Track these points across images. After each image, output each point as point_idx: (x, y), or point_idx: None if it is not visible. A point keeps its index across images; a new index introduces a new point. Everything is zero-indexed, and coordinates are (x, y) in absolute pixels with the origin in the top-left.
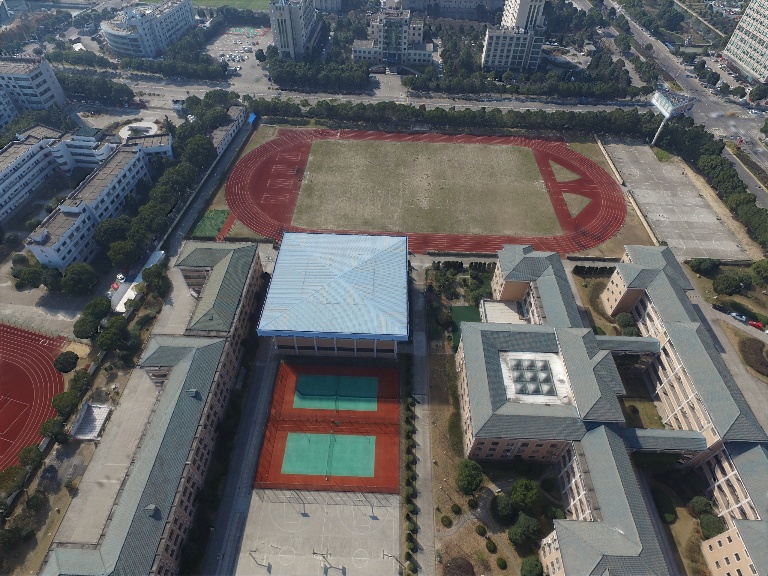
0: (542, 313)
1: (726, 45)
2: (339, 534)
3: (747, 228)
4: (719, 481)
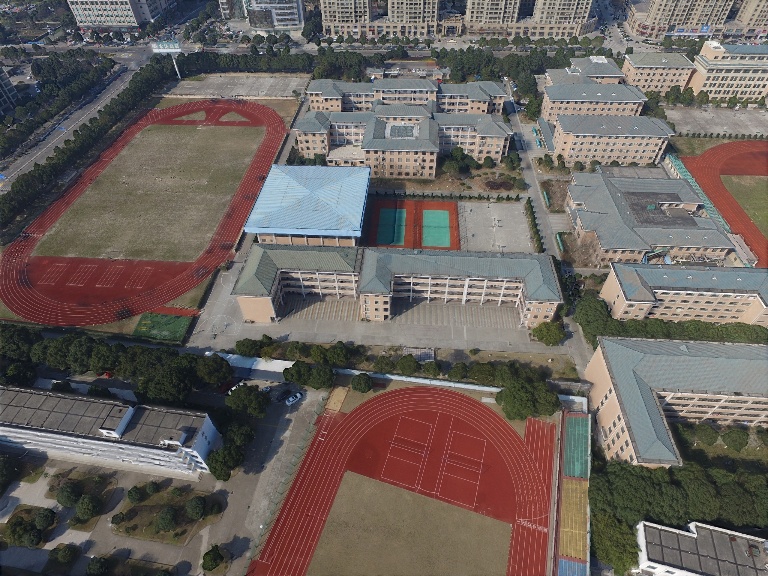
0: (357, 123)
1: (73, 21)
2: (481, 222)
3: (283, 72)
4: (446, 108)
